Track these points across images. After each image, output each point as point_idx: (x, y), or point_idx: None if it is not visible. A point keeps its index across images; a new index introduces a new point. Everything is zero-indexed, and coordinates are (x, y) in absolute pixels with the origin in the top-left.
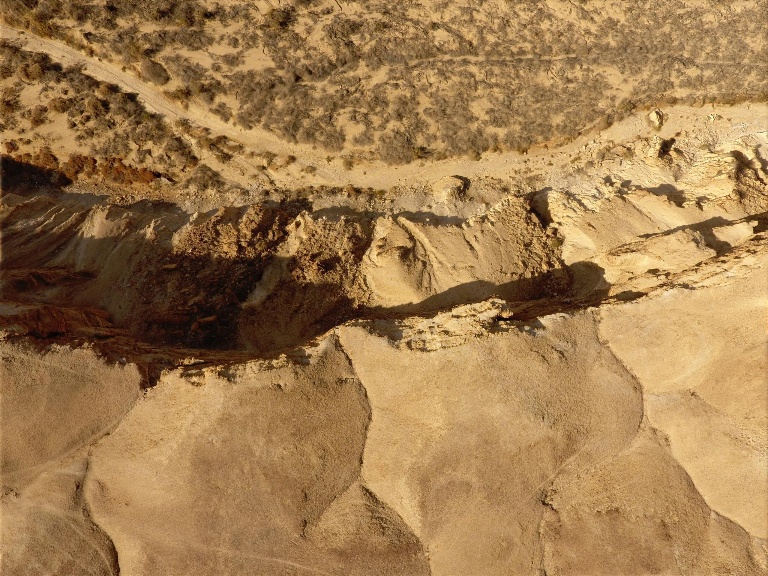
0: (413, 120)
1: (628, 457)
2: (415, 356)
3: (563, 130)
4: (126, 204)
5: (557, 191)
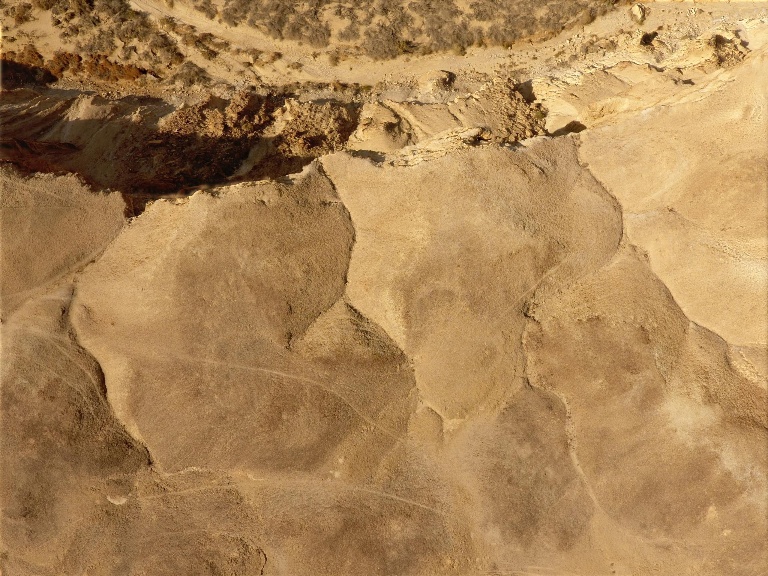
0: (398, 14)
1: (608, 272)
2: (397, 171)
3: (547, 23)
4: (112, 99)
5: (541, 76)
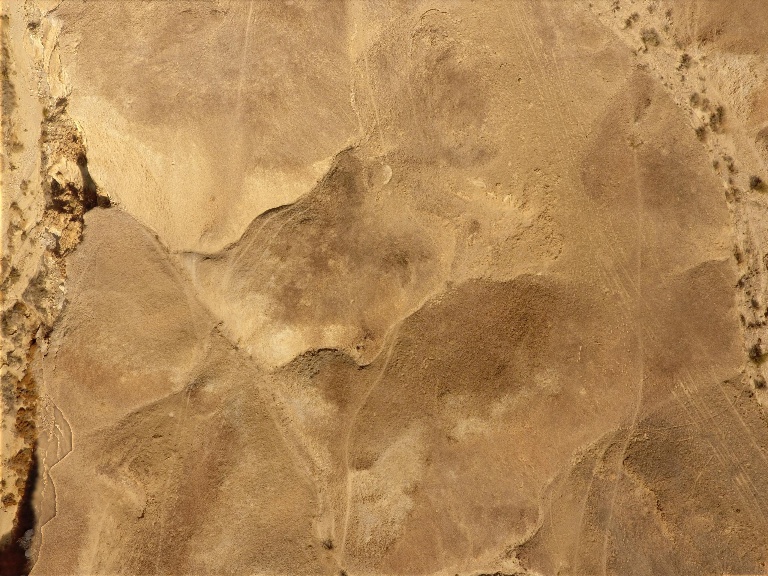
0: None
1: None
2: None
3: None
4: None
5: None
